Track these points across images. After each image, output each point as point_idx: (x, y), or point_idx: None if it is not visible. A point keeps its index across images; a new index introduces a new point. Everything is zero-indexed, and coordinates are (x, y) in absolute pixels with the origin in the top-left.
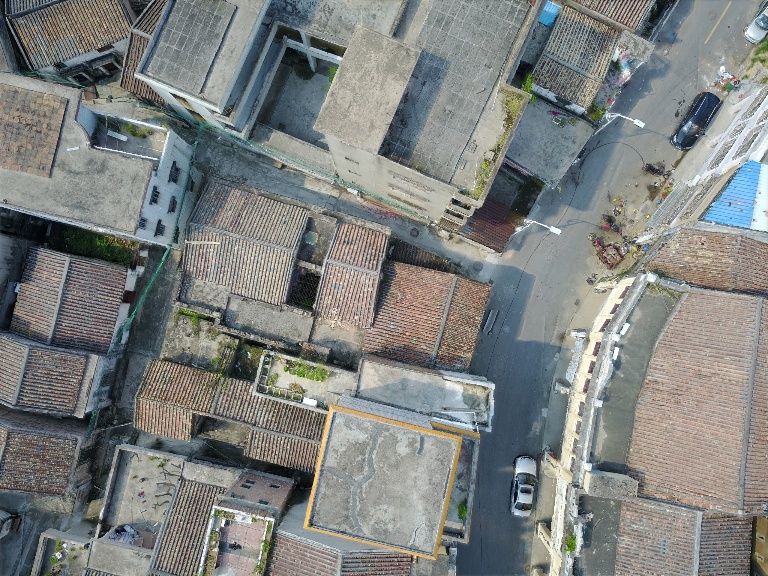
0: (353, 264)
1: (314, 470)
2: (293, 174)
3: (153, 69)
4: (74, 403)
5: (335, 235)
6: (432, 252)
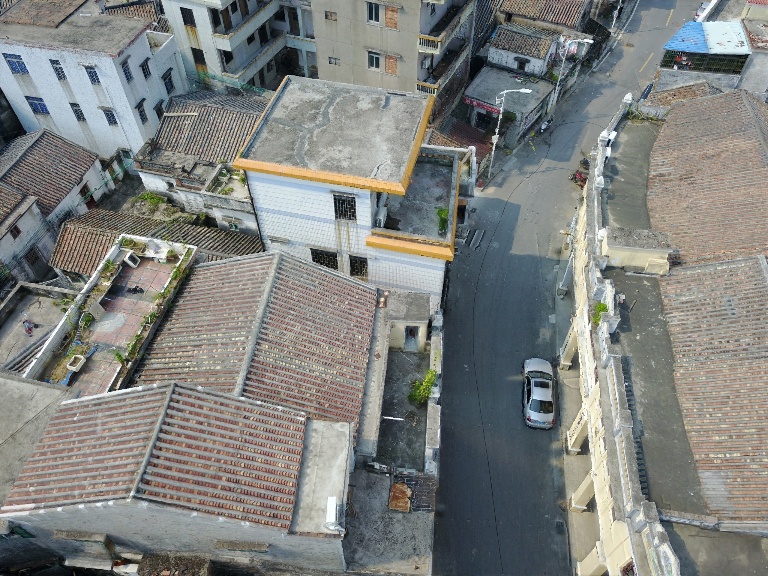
0: None
1: None
2: None
3: None
4: None
5: None
6: None
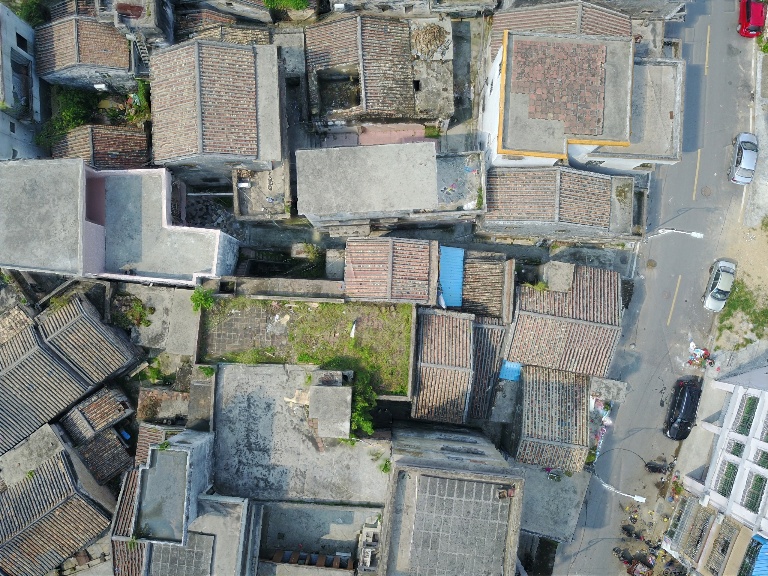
0: None
1: None
2: None
3: None
4: None
5: None
6: None
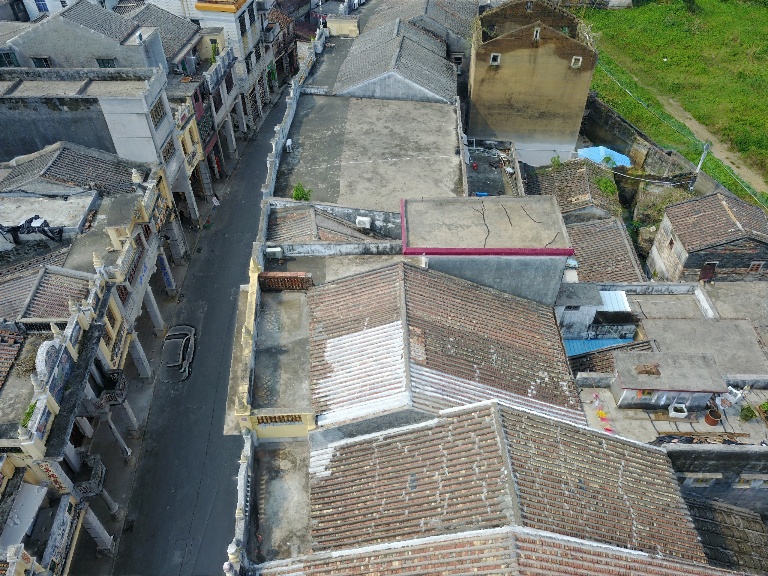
0: None
1: None
2: None
3: None
4: None
5: None
6: None
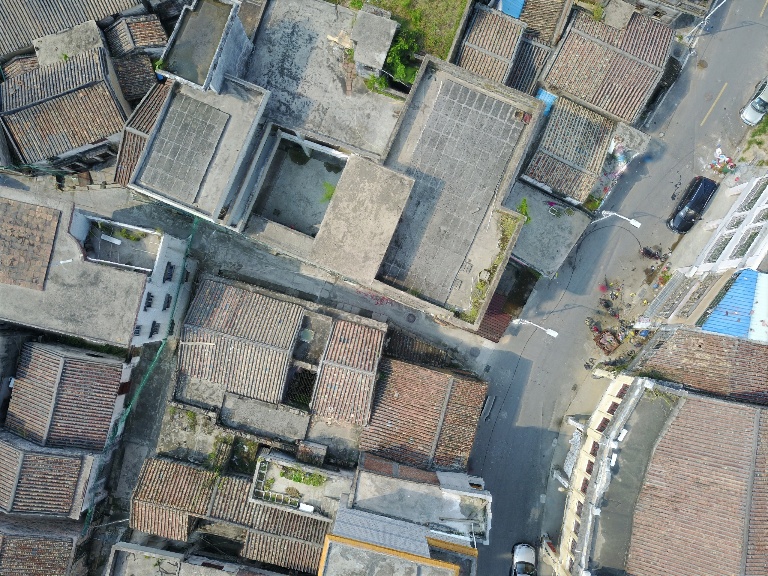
0: (349, 365)
1: (311, 570)
2: (289, 260)
3: (146, 179)
4: (69, 505)
5: (331, 334)
6: (429, 338)
